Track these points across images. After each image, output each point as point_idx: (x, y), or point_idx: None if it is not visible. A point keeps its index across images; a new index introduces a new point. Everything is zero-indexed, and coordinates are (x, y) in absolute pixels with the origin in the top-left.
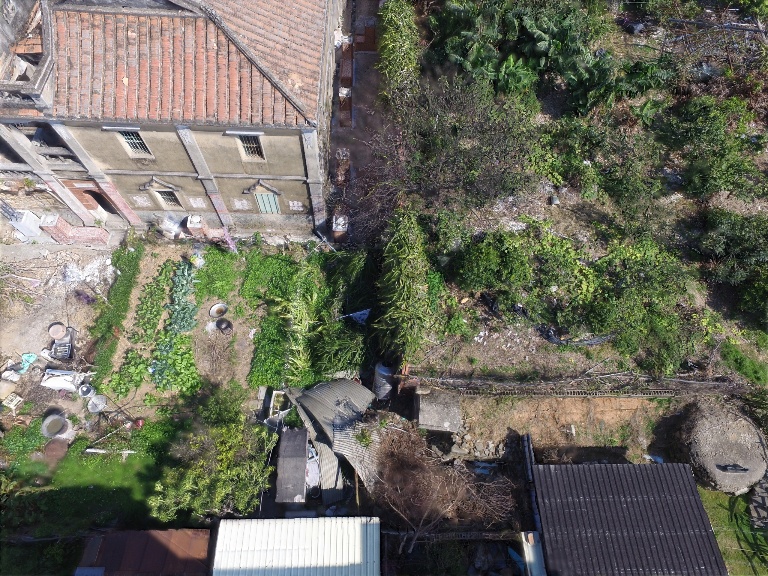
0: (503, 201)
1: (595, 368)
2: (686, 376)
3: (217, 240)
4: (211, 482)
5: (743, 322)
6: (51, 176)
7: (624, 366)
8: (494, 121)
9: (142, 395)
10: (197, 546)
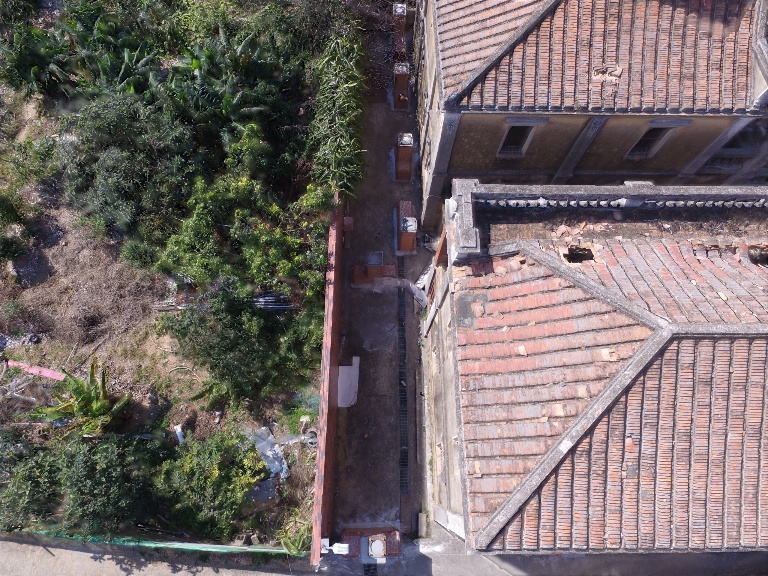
0: None
1: None
2: None
3: None
4: None
5: None
6: None
7: None
8: None
9: None
10: None
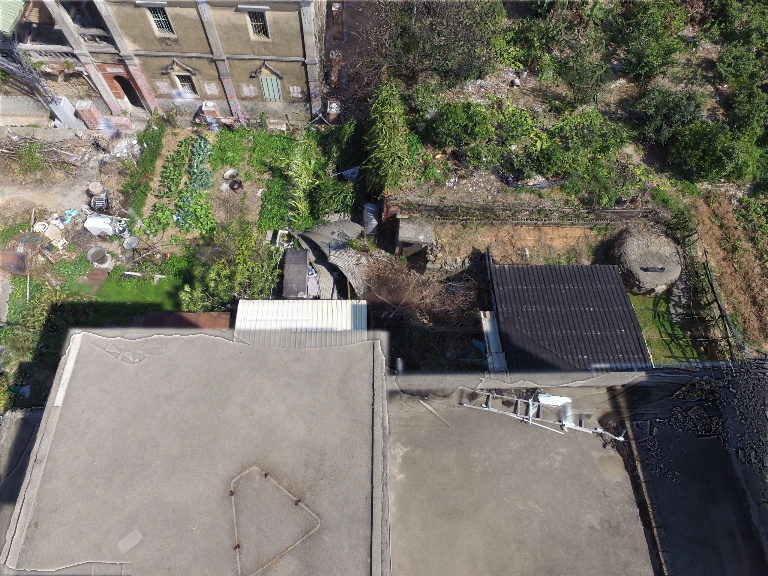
0: (472, 84)
1: (546, 204)
2: (620, 209)
3: (228, 125)
4: (231, 274)
5: (671, 174)
6: (88, 58)
7: (569, 202)
8: (466, 24)
9: (168, 237)
10: (220, 322)
